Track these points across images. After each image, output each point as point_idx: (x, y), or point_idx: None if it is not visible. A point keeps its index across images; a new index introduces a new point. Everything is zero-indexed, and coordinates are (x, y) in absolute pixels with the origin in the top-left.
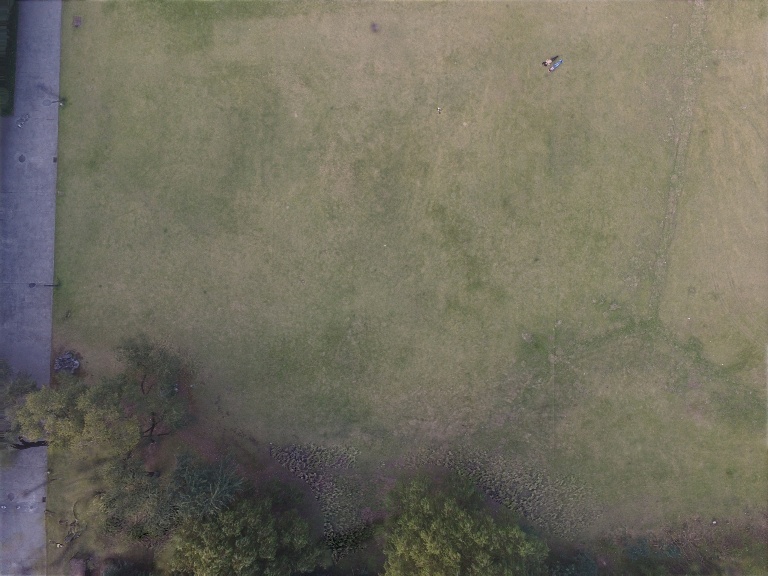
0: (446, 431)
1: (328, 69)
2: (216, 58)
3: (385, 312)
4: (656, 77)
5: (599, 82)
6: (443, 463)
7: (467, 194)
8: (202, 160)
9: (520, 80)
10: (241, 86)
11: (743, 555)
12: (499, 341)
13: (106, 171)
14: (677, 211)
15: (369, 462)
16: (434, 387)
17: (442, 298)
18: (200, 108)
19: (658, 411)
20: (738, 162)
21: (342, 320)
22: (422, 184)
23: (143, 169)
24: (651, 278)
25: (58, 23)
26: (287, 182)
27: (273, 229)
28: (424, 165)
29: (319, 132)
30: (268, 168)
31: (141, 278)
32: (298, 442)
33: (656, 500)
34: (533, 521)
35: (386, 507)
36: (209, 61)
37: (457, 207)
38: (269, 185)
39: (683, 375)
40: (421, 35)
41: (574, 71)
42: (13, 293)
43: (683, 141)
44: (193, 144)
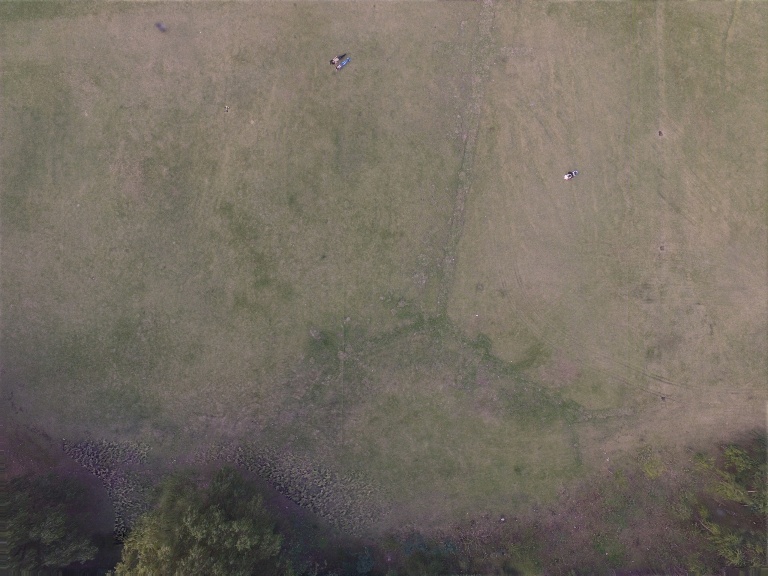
0: (236, 427)
1: (117, 68)
2: (8, 58)
3: (174, 309)
4: (444, 74)
5: (387, 80)
6: (233, 459)
7: (253, 192)
8: None
9: (307, 78)
10: (33, 86)
11: (530, 552)
12: (287, 338)
13: None
14: (465, 208)
15: (160, 458)
16: (223, 383)
17: (230, 295)
18: None
19: (445, 408)
20: (525, 159)
21: (132, 317)
22: (210, 182)
23: None
24: (439, 275)
25: None
26: (78, 180)
27: (64, 227)
28: (212, 163)
29: (109, 131)
30: (59, 166)
31: None
32: (90, 438)
33: (444, 497)
34: (322, 517)
35: (177, 503)
36: (1, 61)
37: (244, 205)
38: (60, 183)
39: (471, 372)
40: (209, 34)
41: (362, 69)
42: None
43: (471, 138)
44: None
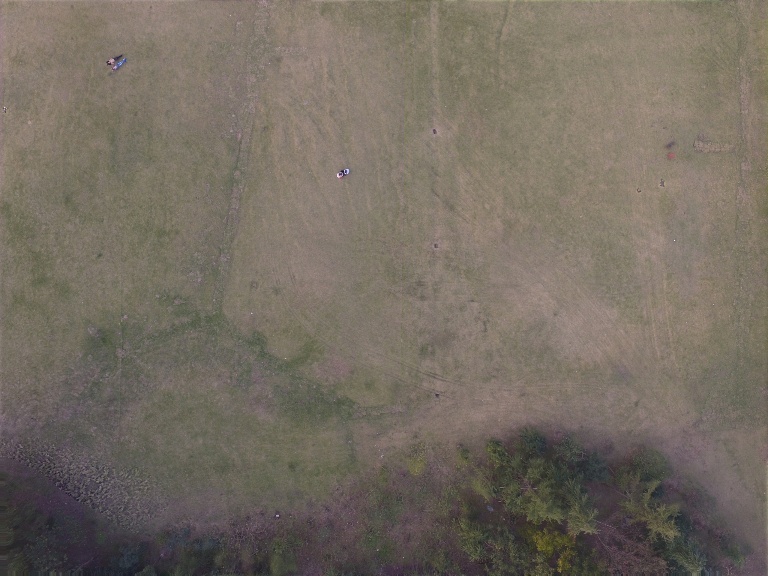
0: (16, 424)
1: None
2: None
3: None
4: (220, 74)
5: (163, 80)
6: (13, 456)
7: (30, 191)
8: None
9: (84, 79)
10: None
11: (303, 548)
12: (65, 335)
13: None
14: (240, 207)
15: None
16: (2, 381)
17: (9, 293)
18: None
19: (219, 405)
20: (299, 158)
21: None
22: None
23: None
24: (215, 273)
25: None
26: None
27: None
28: None
29: None
30: None
31: None
32: None
33: (220, 493)
34: (101, 513)
35: None
36: None
37: (21, 204)
38: None
39: (246, 369)
40: None
41: (138, 69)
42: None
43: (246, 137)
44: None
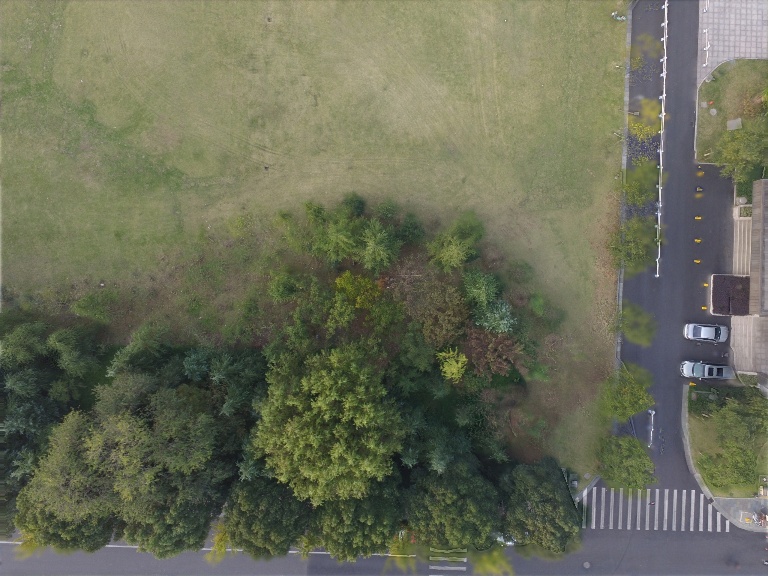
0: None
1: None
2: None
3: None
4: None
5: None
6: None
7: None
8: None
9: None
10: None
11: (126, 316)
12: None
13: None
14: None
15: None
16: None
17: None
18: None
19: (45, 171)
20: None
21: None
22: None
23: None
24: (46, 40)
25: None
26: None
27: None
28: None
29: None
30: None
31: None
32: None
33: (45, 261)
34: None
35: None
36: None
37: None
38: None
39: (75, 137)
40: None
41: None
42: None
43: None
44: None
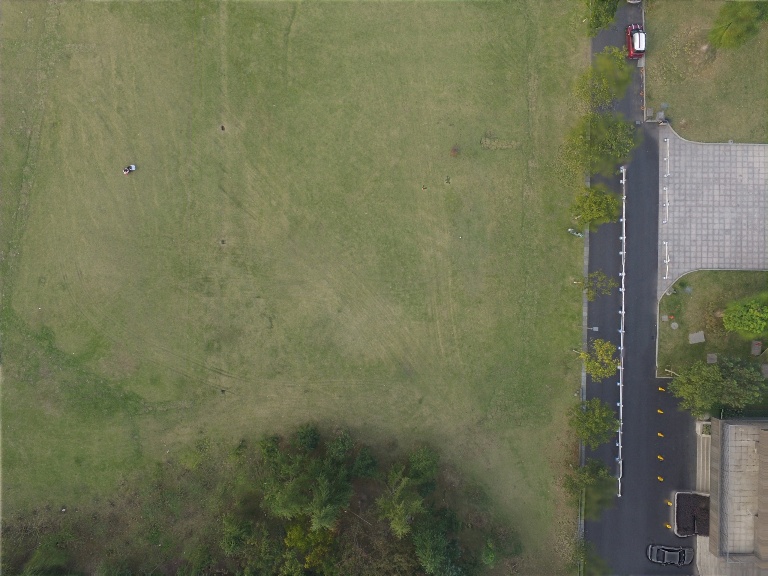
0: None
1: None
2: None
3: None
4: (10, 71)
5: None
6: None
7: None
8: None
9: None
10: None
11: (87, 543)
12: None
13: None
14: (29, 202)
15: None
16: None
17: None
18: None
19: (6, 399)
20: (86, 154)
21: None
22: None
23: None
24: (4, 268)
25: None
26: None
27: None
28: None
29: None
30: None
31: None
32: None
33: (8, 487)
34: None
35: None
36: None
37: None
38: None
39: (34, 364)
40: None
41: None
42: None
43: (35, 133)
44: None
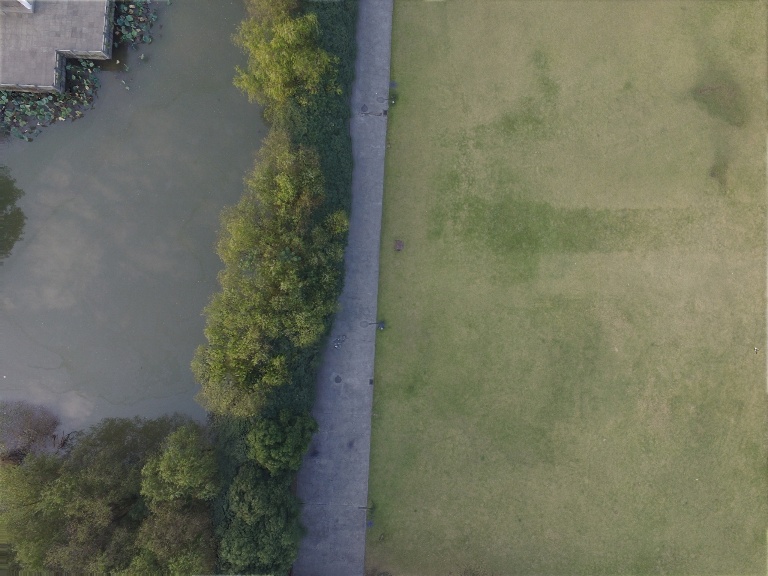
0: None
1: (650, 306)
2: (541, 291)
3: (694, 544)
4: None
5: None
6: None
7: None
8: (522, 390)
9: None
10: (564, 319)
11: None
12: None
13: (424, 397)
14: None
15: None
16: None
17: (750, 532)
18: (522, 339)
19: None
20: None
21: (652, 550)
22: (736, 421)
23: (462, 397)
24: None
25: (377, 244)
26: (605, 415)
27: (589, 460)
28: (739, 403)
29: (639, 367)
30: (587, 400)
31: (457, 505)
32: None
33: None
34: None
35: None
36: (534, 293)
37: None
38: (587, 417)
39: None
40: (741, 275)
41: None
42: (326, 514)
43: None
44: (514, 374)
